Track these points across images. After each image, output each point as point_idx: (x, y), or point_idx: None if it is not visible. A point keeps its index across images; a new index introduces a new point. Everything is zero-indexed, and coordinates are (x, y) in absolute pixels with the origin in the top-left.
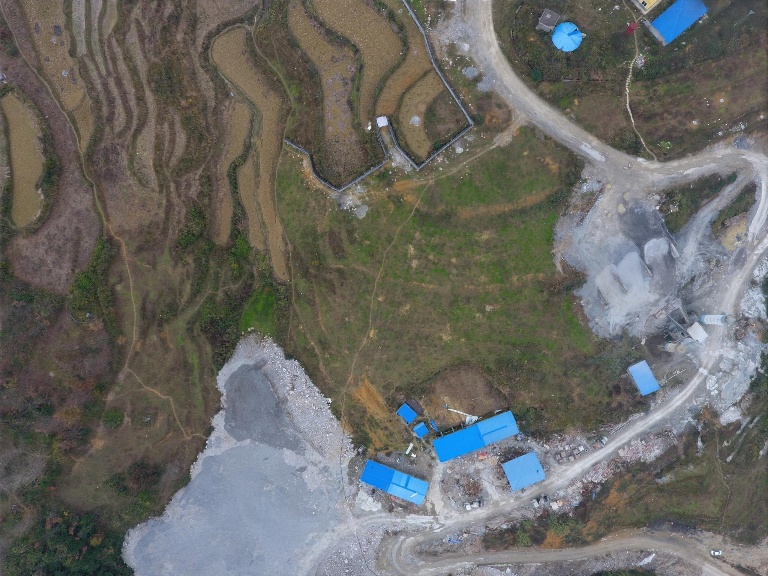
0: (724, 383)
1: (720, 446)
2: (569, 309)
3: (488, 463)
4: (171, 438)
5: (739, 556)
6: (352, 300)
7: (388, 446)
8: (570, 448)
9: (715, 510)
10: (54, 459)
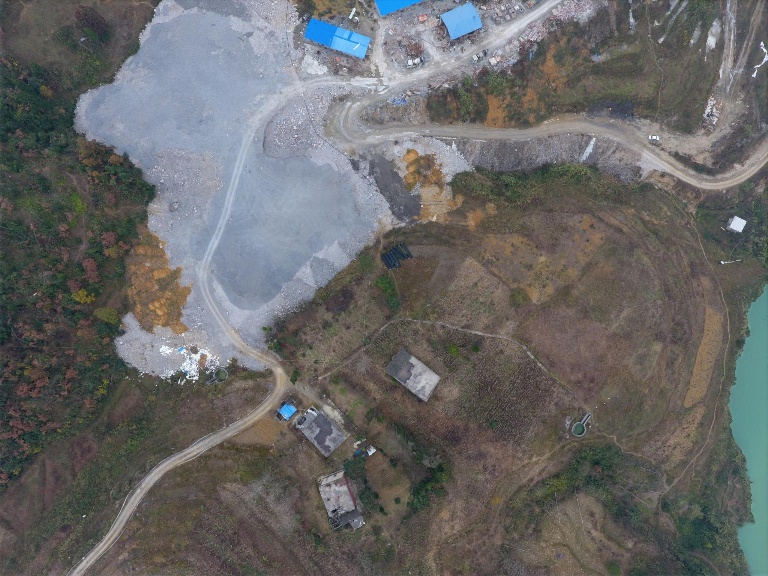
0: None
1: (651, 25)
2: None
3: (428, 25)
4: None
5: (676, 144)
6: None
7: (331, 10)
8: (506, 8)
9: (650, 91)
10: None
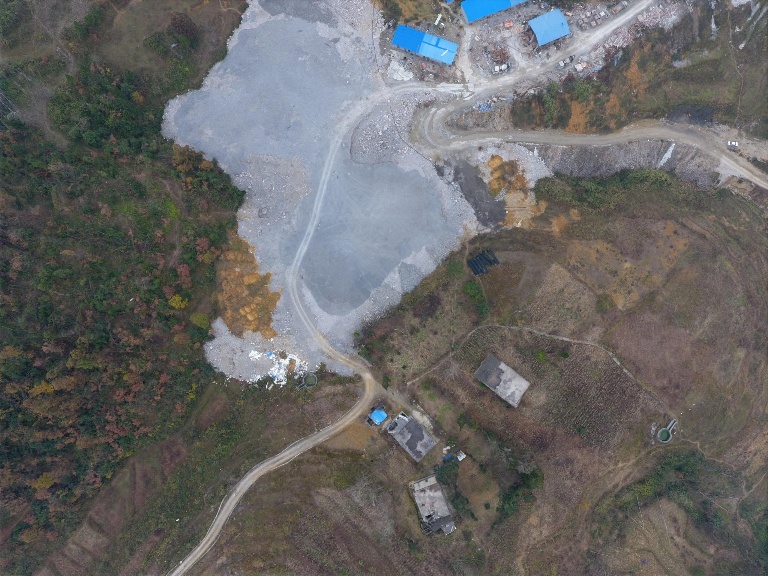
0: None
1: (733, 31)
2: None
3: (514, 32)
4: (208, 6)
5: (754, 150)
6: None
7: (417, 16)
8: (592, 14)
9: (730, 97)
10: (97, 2)
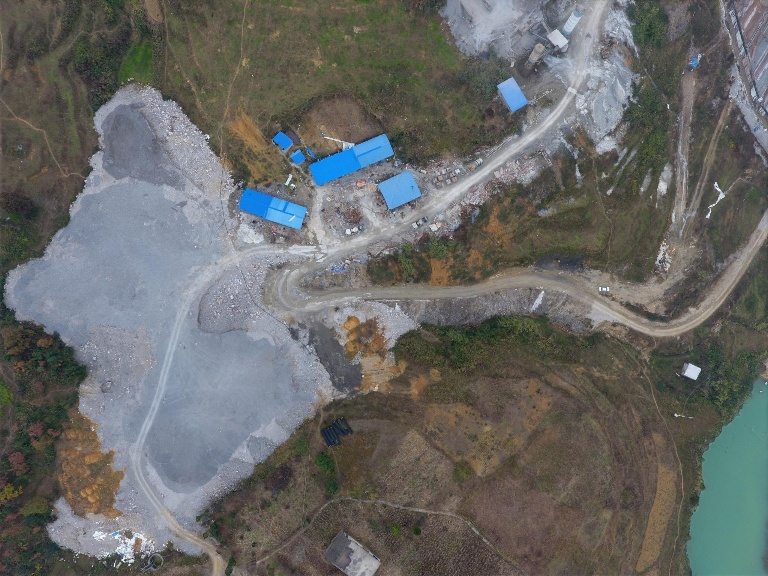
0: (592, 100)
1: (599, 177)
2: (436, 29)
3: (367, 191)
4: (47, 174)
5: (627, 294)
6: (223, 29)
7: (267, 177)
8: (447, 172)
9: (599, 243)
10: None
